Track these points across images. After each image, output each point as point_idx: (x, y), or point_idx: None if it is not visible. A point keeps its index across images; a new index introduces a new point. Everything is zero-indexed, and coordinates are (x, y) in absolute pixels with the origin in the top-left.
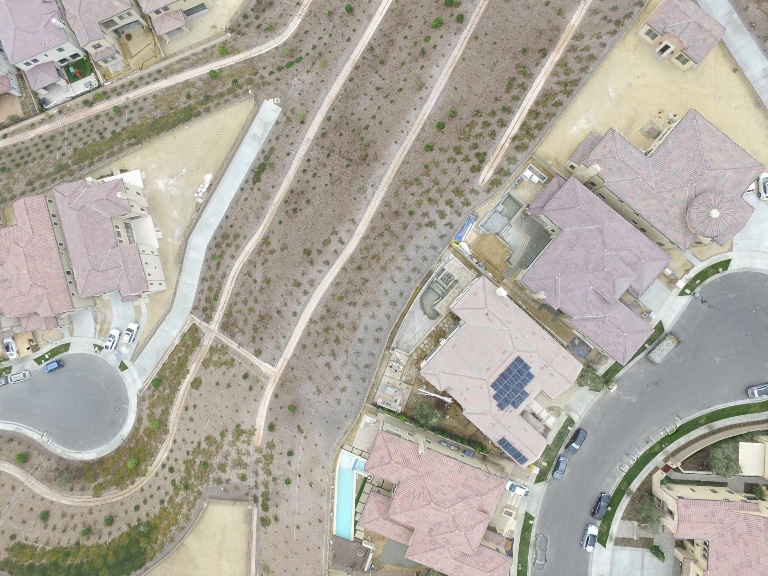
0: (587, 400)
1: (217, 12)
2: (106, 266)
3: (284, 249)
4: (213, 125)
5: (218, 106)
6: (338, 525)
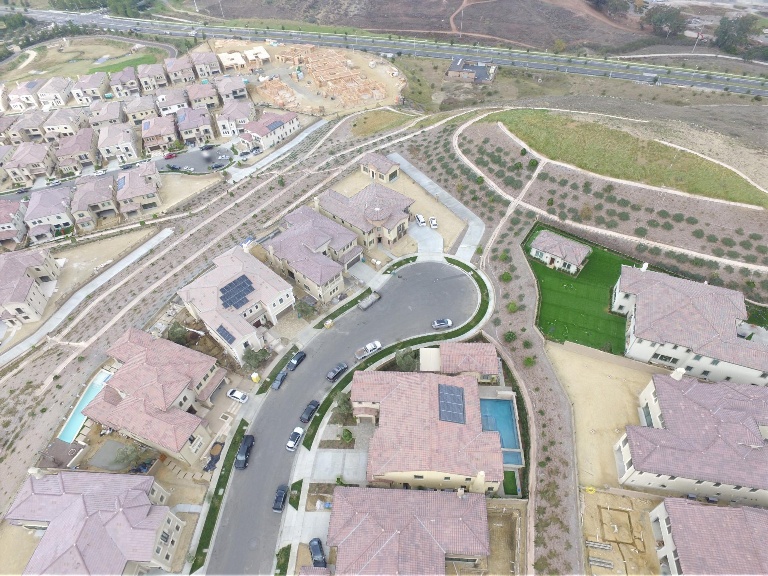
0: (311, 335)
1: (163, 208)
2: (4, 288)
3: (135, 281)
4: (127, 238)
5: None
6: (66, 434)
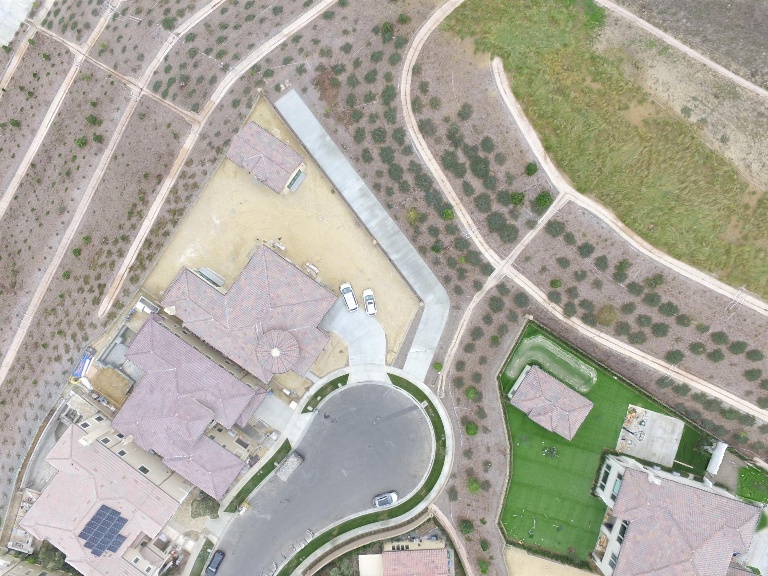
0: (224, 521)
1: None
2: None
3: None
4: None
5: None
6: None
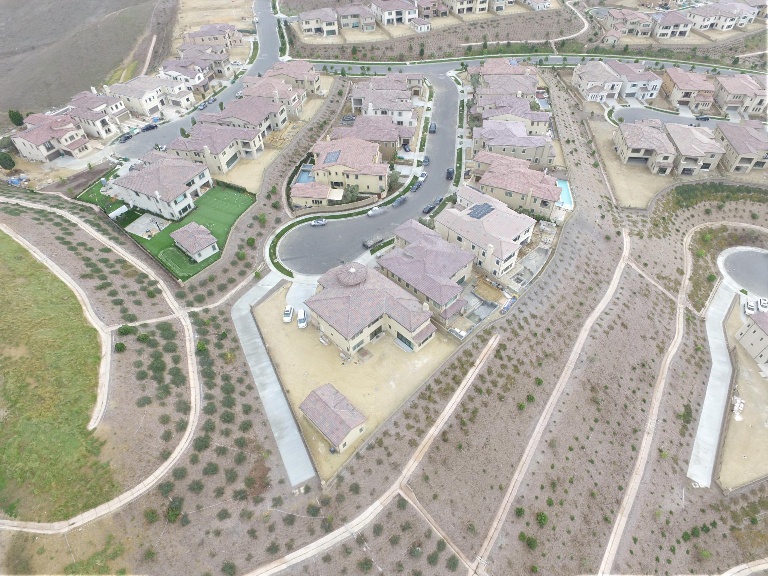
0: None
1: None
2: None
3: (644, 336)
4: (757, 466)
5: (761, 487)
6: None
